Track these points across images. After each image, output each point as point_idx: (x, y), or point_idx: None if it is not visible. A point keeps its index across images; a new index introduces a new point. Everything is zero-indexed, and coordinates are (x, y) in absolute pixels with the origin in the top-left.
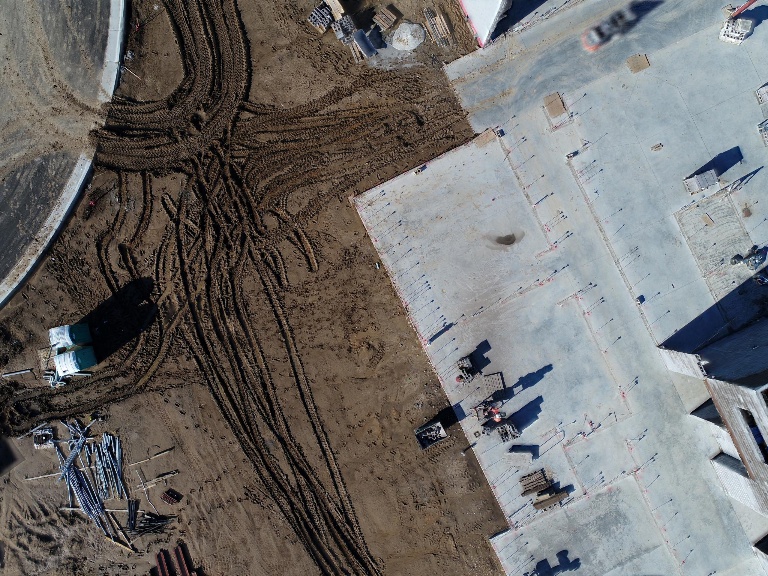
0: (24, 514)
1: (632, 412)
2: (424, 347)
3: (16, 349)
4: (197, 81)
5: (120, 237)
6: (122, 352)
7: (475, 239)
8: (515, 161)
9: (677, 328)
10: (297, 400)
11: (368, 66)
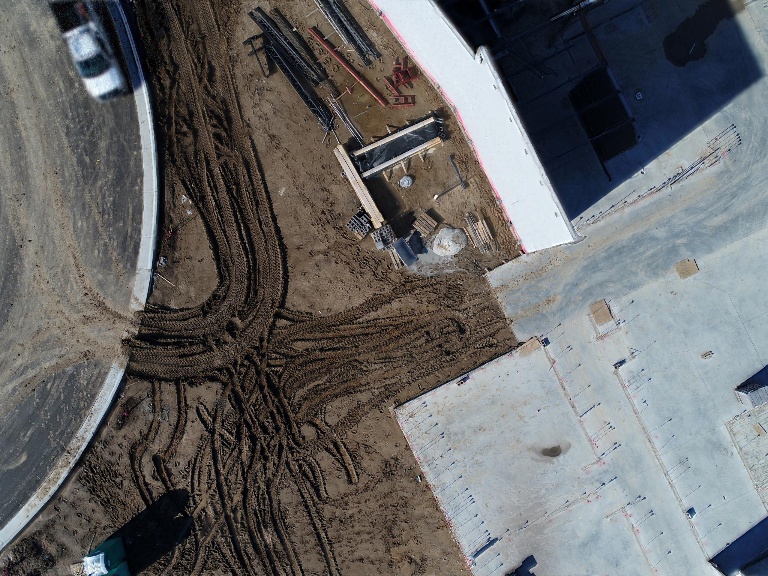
0: None
1: None
2: None
3: (48, 564)
4: (232, 287)
5: (154, 448)
6: (157, 566)
7: (520, 451)
8: (561, 371)
9: (729, 542)
10: None
11: (408, 272)
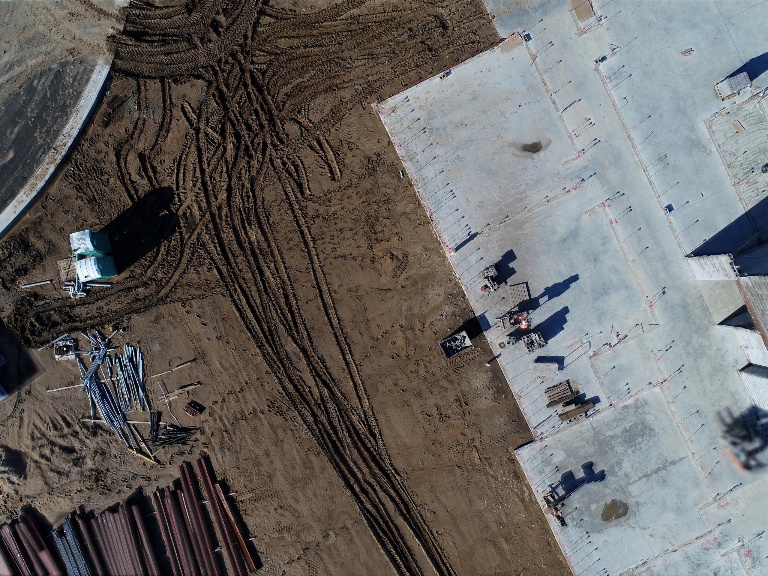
0: (46, 426)
1: (659, 323)
2: (448, 257)
3: (35, 260)
4: None
5: (139, 146)
6: (142, 263)
7: (501, 147)
8: (542, 66)
9: (706, 237)
10: (320, 311)
11: None
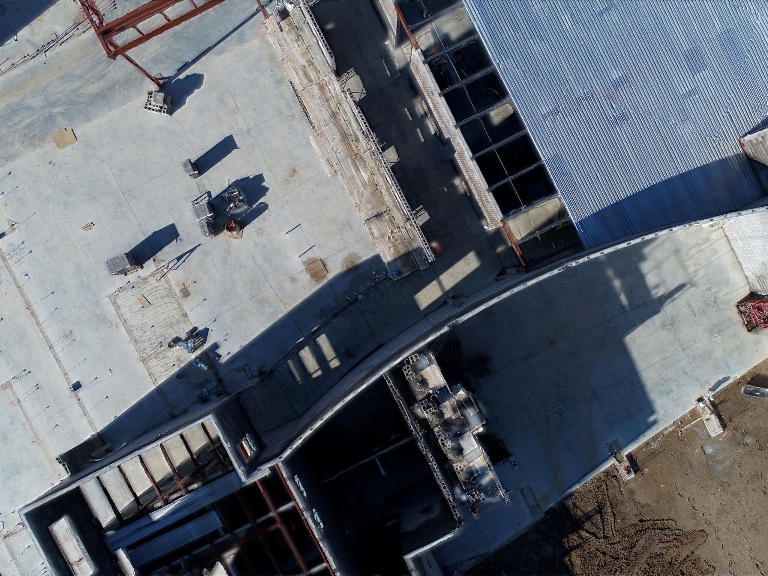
0: None
1: None
2: None
3: None
4: None
5: None
6: None
7: None
8: None
9: (116, 414)
10: None
11: None
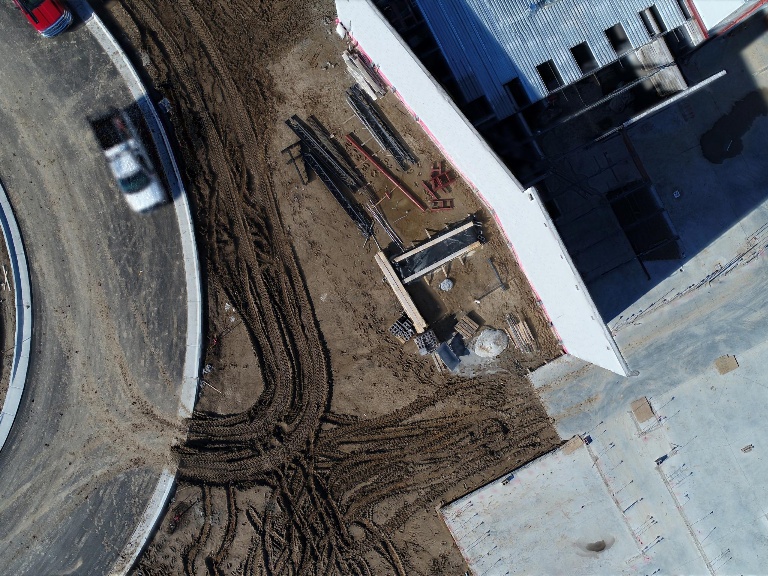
0: None
1: None
2: None
3: None
4: (277, 392)
5: (206, 550)
6: None
7: (565, 547)
8: (603, 467)
9: None
10: None
11: (451, 374)
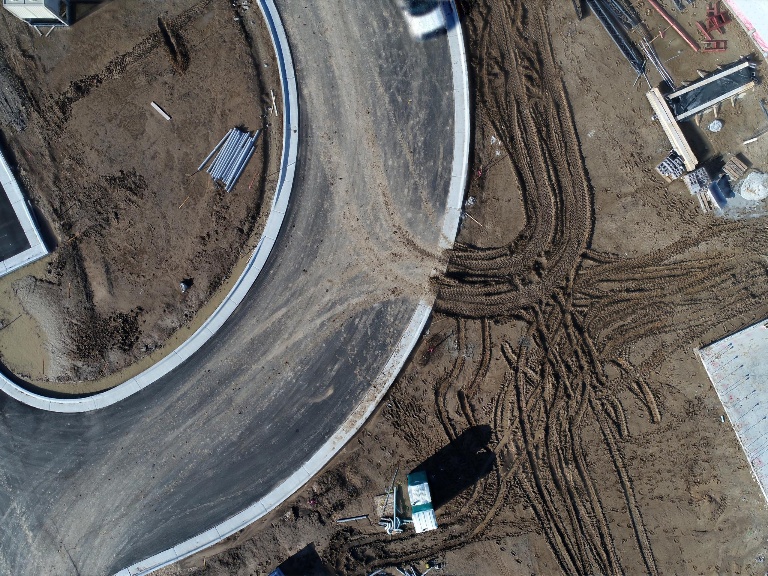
0: None
1: None
2: None
3: (353, 495)
4: (538, 228)
5: (458, 384)
6: (459, 500)
7: None
8: None
9: None
10: (635, 551)
11: (715, 216)
